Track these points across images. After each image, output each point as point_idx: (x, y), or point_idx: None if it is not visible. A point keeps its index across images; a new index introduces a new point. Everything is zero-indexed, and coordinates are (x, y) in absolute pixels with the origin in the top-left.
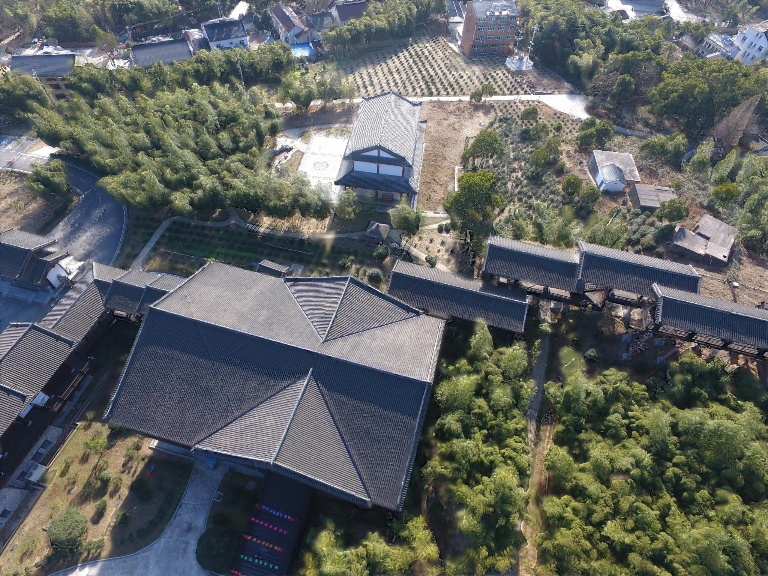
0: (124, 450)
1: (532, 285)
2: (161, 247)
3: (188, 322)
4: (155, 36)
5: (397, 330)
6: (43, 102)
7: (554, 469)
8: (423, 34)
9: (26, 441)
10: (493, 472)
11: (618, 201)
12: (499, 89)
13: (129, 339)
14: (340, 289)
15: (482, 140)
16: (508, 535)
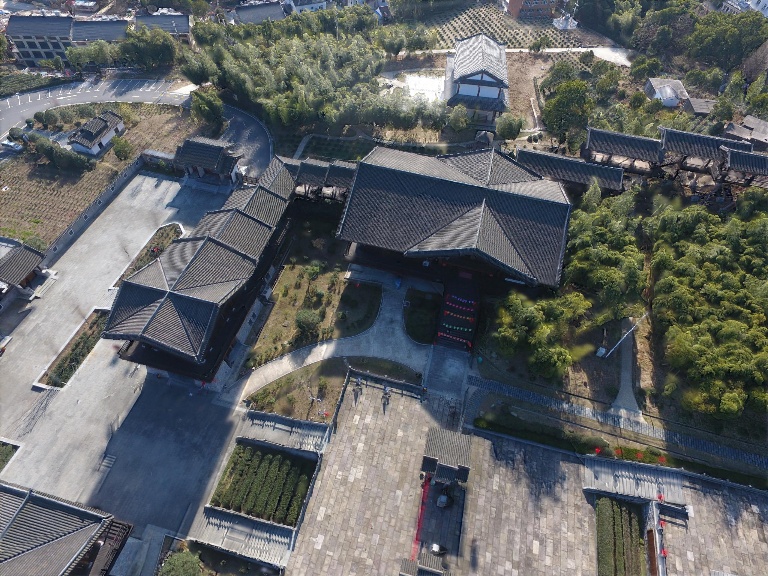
0: (326, 280)
1: (622, 161)
2: (308, 155)
3: (389, 172)
4: (251, 0)
5: (532, 184)
6: (172, 52)
7: (660, 263)
8: (475, 1)
9: (266, 264)
10: (618, 265)
11: (675, 112)
12: (551, 43)
13: (305, 213)
14: (488, 156)
15: (560, 69)
16: (635, 297)
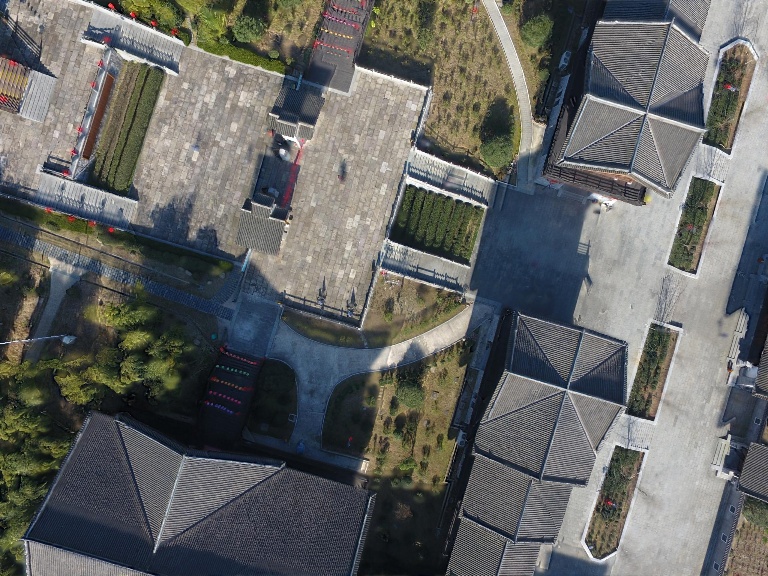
0: (393, 458)
1: None
2: None
3: None
4: None
5: None
6: None
7: None
8: None
9: (466, 469)
10: None
11: None
12: None
13: None
14: None
15: None
16: None
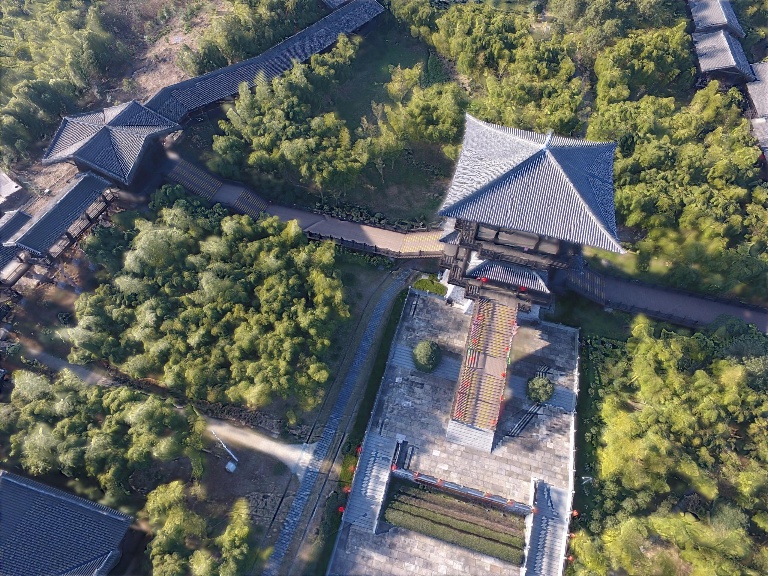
0: None
1: None
2: None
3: None
4: None
5: None
6: None
7: (141, 371)
8: None
9: None
10: (127, 424)
11: None
12: None
13: None
14: None
15: None
16: (179, 419)
